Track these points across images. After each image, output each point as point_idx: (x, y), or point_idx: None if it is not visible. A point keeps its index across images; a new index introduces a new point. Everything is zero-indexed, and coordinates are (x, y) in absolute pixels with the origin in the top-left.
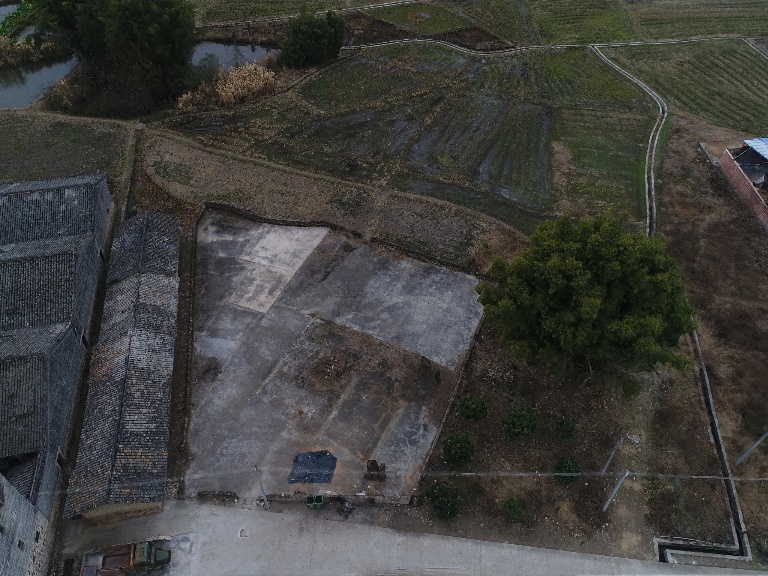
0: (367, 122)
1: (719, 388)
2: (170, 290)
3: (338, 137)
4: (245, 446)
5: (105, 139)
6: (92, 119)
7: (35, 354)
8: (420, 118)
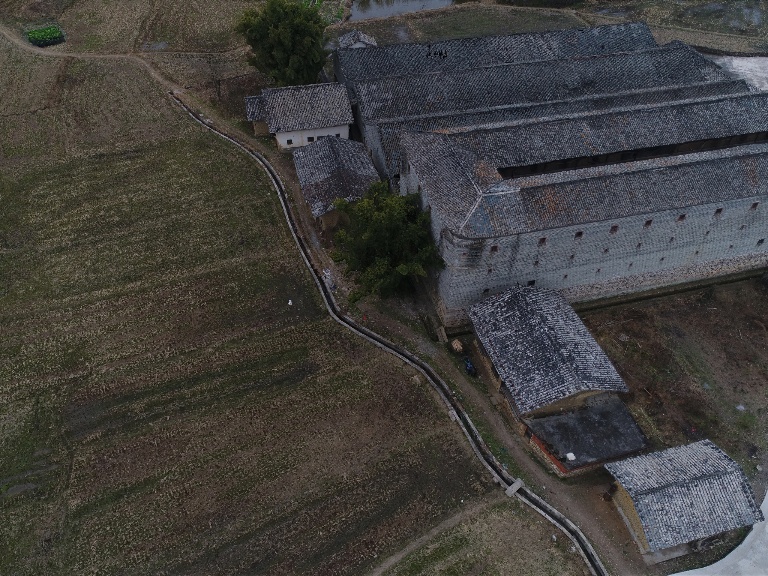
0: (722, 9)
1: None
2: None
3: (713, 17)
4: None
5: (560, 18)
6: (536, 8)
7: (739, 80)
8: (755, 7)
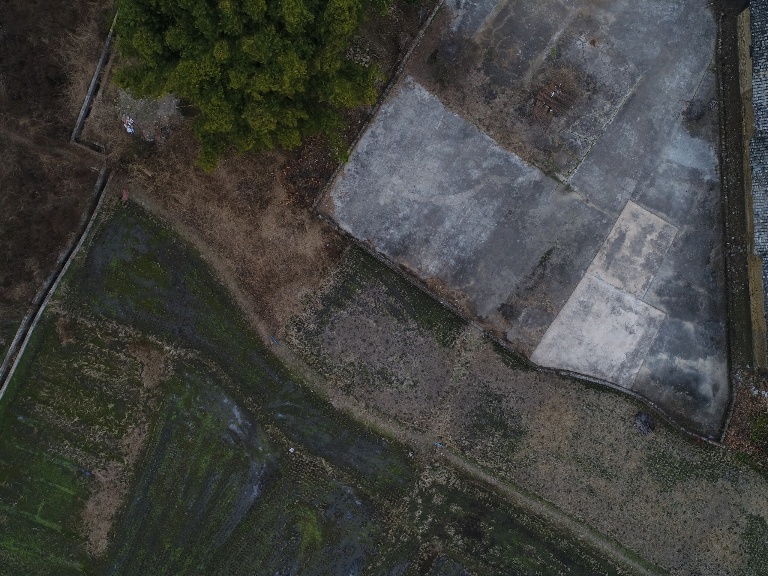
0: None
1: (108, 6)
2: (767, 225)
3: None
4: (655, 9)
5: None
6: None
7: None
8: None
